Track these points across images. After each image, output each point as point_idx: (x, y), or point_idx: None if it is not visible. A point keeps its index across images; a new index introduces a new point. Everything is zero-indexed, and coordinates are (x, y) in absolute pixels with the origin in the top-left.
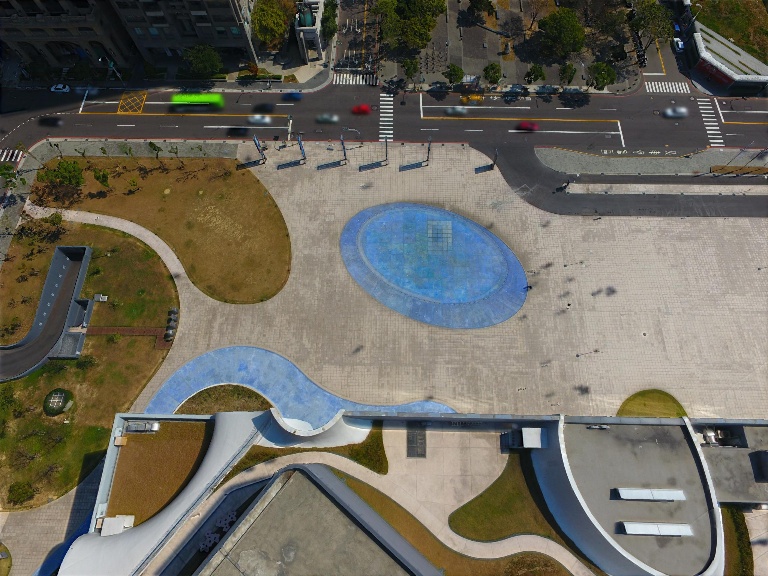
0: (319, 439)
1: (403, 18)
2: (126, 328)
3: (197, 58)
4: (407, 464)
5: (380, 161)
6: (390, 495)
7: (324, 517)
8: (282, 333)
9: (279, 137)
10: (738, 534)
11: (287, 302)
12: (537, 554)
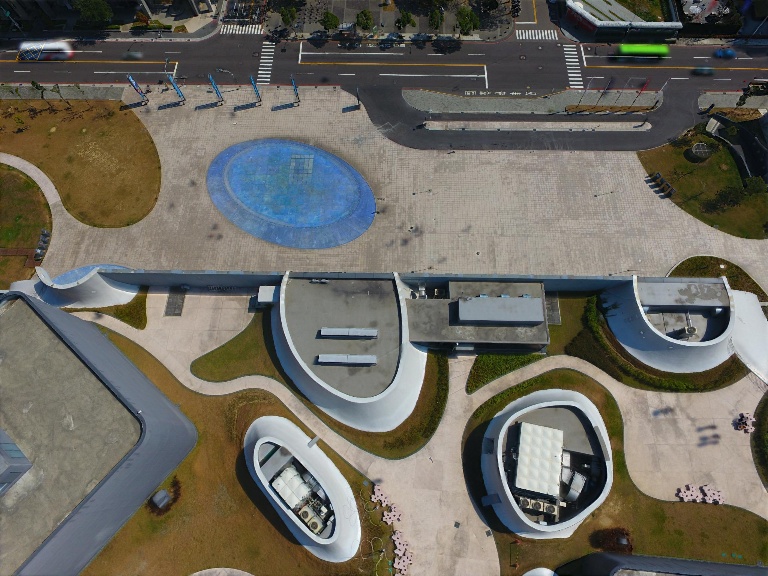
0: (86, 299)
1: None
2: (0, 249)
3: (86, 7)
4: (163, 321)
5: (255, 102)
6: (143, 346)
7: (33, 333)
8: (143, 253)
9: (163, 81)
10: (440, 375)
11: (151, 226)
12: (259, 390)
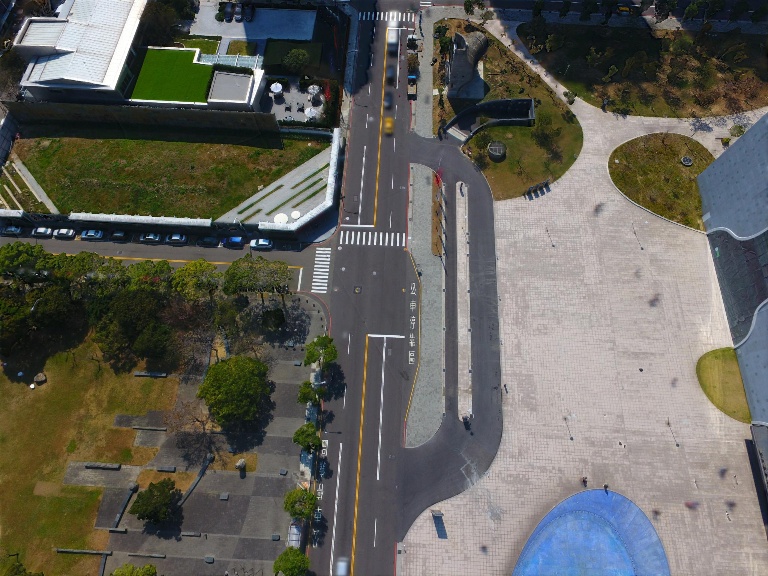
0: None
1: None
2: None
3: None
4: None
5: None
6: None
7: None
8: None
9: None
10: None
11: None
12: None
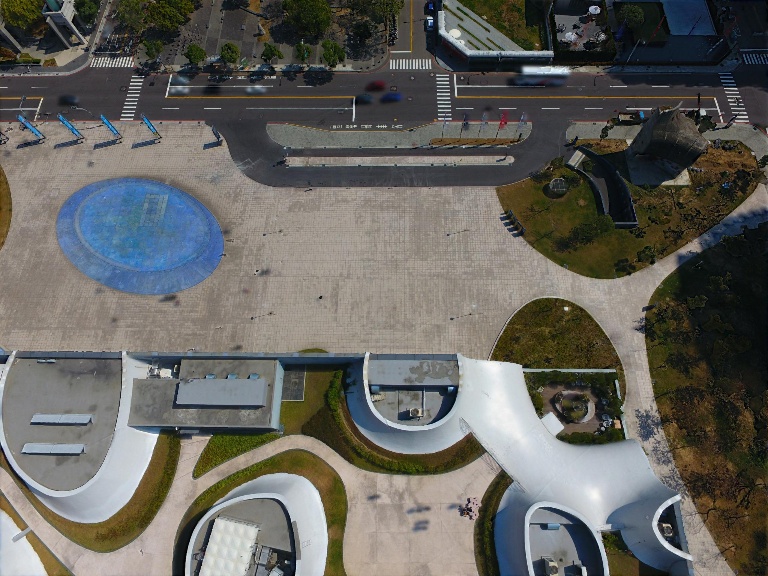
0: None
1: (159, 2)
2: None
3: None
4: None
5: (116, 139)
6: None
7: None
8: None
9: (26, 118)
10: (169, 458)
11: None
12: None
